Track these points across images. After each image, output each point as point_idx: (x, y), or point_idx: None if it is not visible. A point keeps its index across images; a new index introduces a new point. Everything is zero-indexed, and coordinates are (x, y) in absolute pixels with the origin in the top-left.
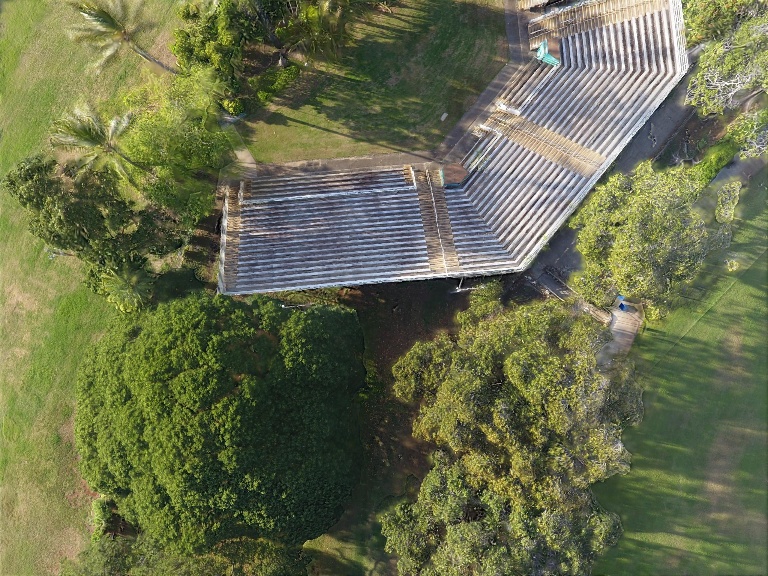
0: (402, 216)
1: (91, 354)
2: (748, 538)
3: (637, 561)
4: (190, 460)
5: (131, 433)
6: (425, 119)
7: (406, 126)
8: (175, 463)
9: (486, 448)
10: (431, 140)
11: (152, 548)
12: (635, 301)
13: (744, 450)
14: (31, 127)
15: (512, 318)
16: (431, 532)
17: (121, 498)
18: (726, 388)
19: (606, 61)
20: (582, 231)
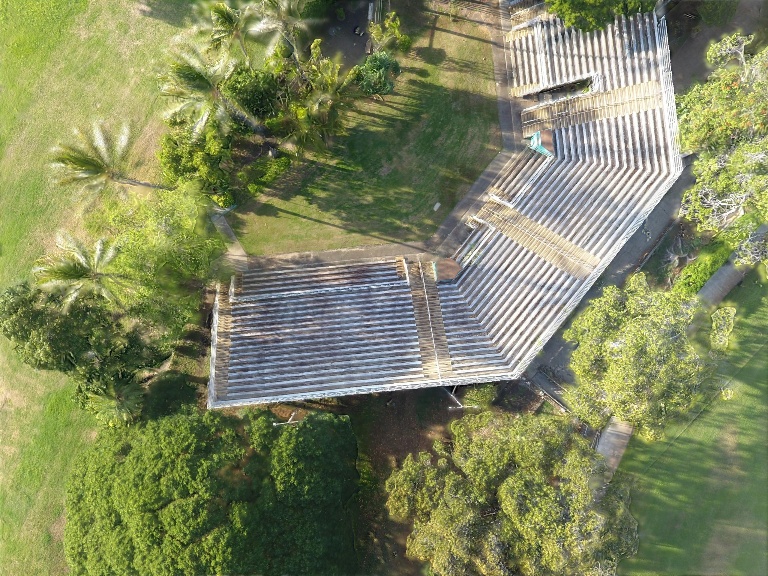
0: (395, 315)
1: (80, 465)
2: None
3: None
4: None
5: (121, 559)
6: (418, 209)
7: (398, 216)
8: None
9: None
10: (424, 230)
11: None
12: None
13: (739, 549)
14: (17, 220)
15: (506, 435)
16: None
17: None
18: (721, 487)
19: (600, 156)
20: (576, 351)
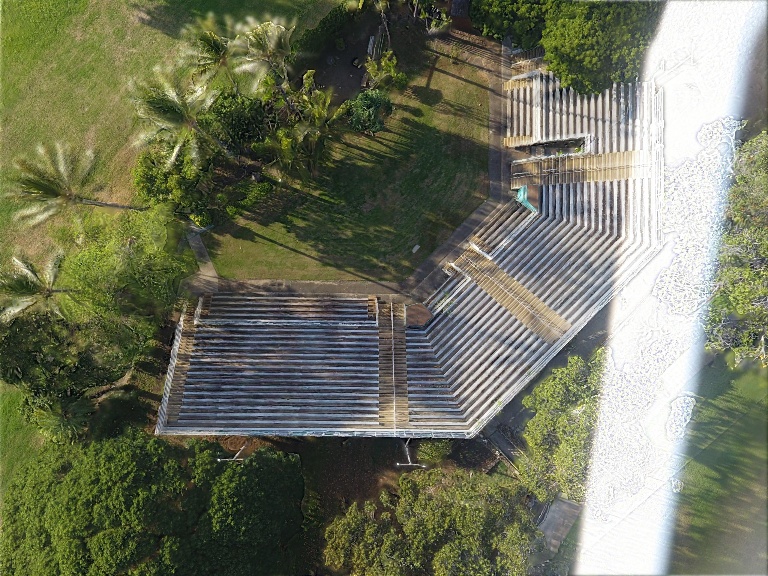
0: (359, 356)
1: (22, 475)
2: None
3: None
4: None
5: None
6: (396, 249)
7: (376, 254)
8: None
9: None
10: (400, 271)
11: None
12: None
13: None
14: None
15: (452, 497)
16: None
17: None
18: (669, 568)
19: (584, 218)
20: (531, 422)
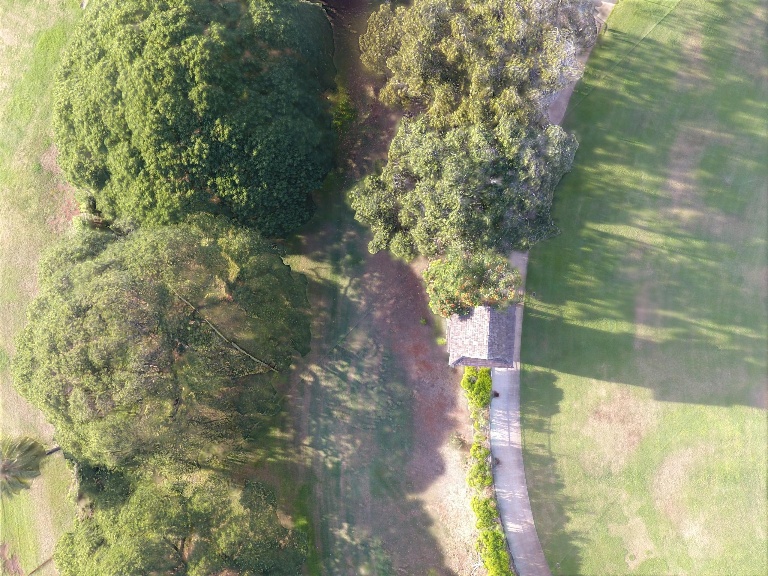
0: None
1: None
2: (709, 235)
3: (601, 252)
4: (161, 97)
5: (105, 86)
6: None
7: None
8: (147, 102)
9: (447, 76)
10: None
11: (129, 225)
12: (596, 4)
13: (704, 151)
14: None
15: None
16: (398, 190)
17: (99, 190)
18: (686, 90)
19: None
20: None
